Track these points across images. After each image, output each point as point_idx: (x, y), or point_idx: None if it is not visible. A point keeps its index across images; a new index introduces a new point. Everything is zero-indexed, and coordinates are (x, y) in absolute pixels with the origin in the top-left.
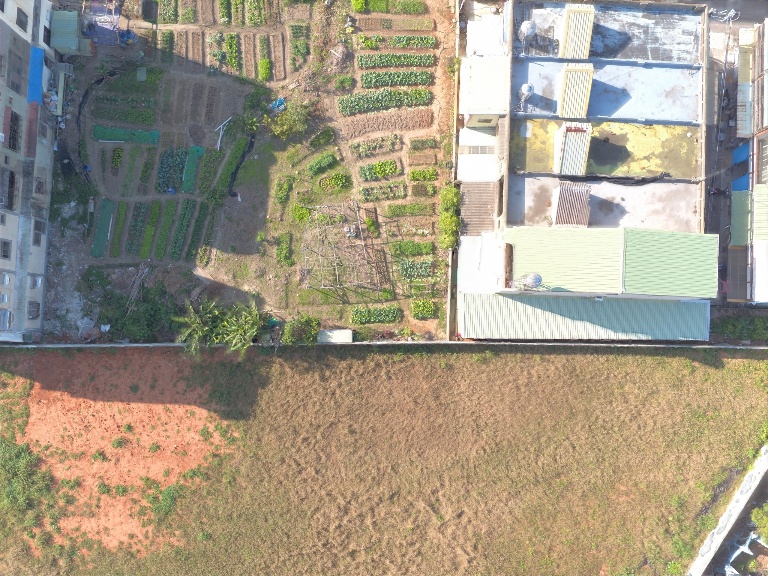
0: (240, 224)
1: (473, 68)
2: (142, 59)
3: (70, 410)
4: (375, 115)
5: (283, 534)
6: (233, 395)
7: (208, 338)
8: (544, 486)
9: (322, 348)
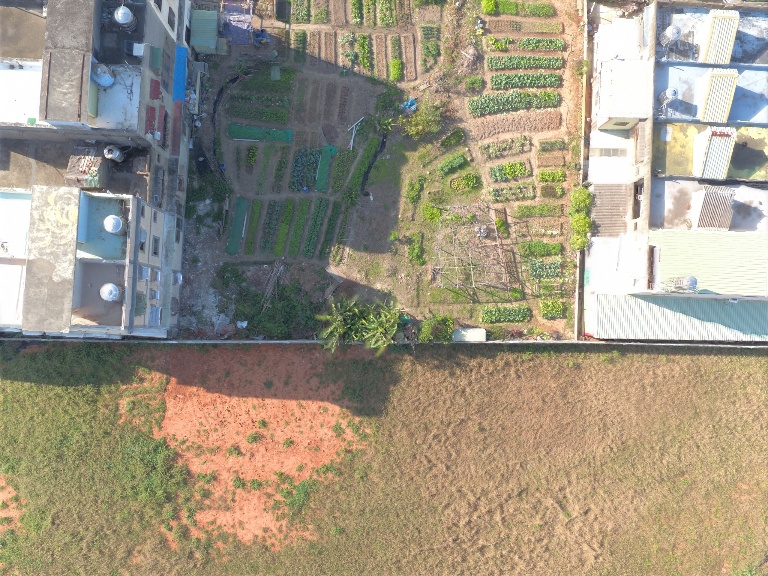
0: (372, 223)
1: (614, 72)
2: (275, 58)
3: (206, 405)
4: (505, 116)
5: (414, 529)
6: (365, 392)
7: (346, 336)
8: (669, 484)
9: (452, 346)
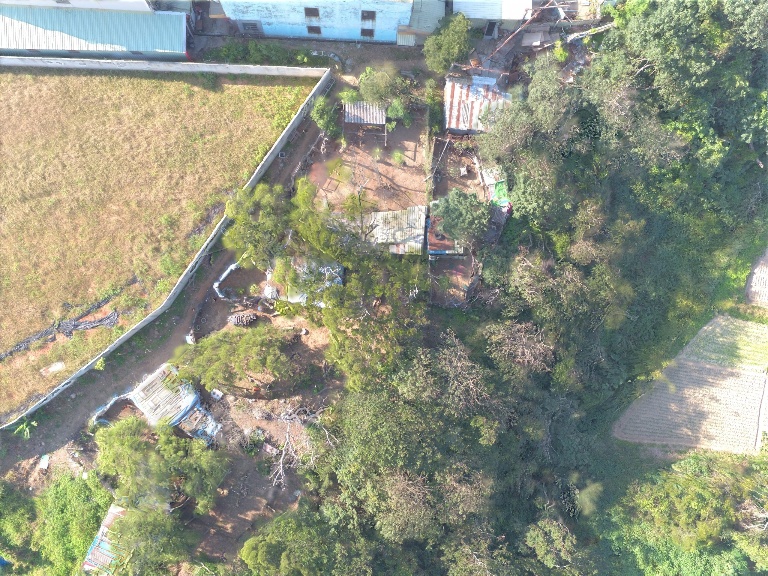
0: None
1: None
2: None
3: None
4: None
5: None
6: None
7: None
8: (32, 203)
9: None
